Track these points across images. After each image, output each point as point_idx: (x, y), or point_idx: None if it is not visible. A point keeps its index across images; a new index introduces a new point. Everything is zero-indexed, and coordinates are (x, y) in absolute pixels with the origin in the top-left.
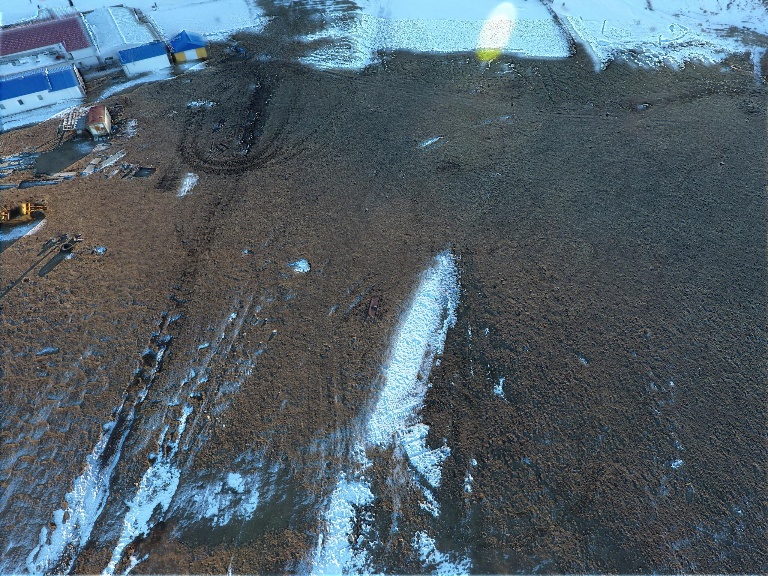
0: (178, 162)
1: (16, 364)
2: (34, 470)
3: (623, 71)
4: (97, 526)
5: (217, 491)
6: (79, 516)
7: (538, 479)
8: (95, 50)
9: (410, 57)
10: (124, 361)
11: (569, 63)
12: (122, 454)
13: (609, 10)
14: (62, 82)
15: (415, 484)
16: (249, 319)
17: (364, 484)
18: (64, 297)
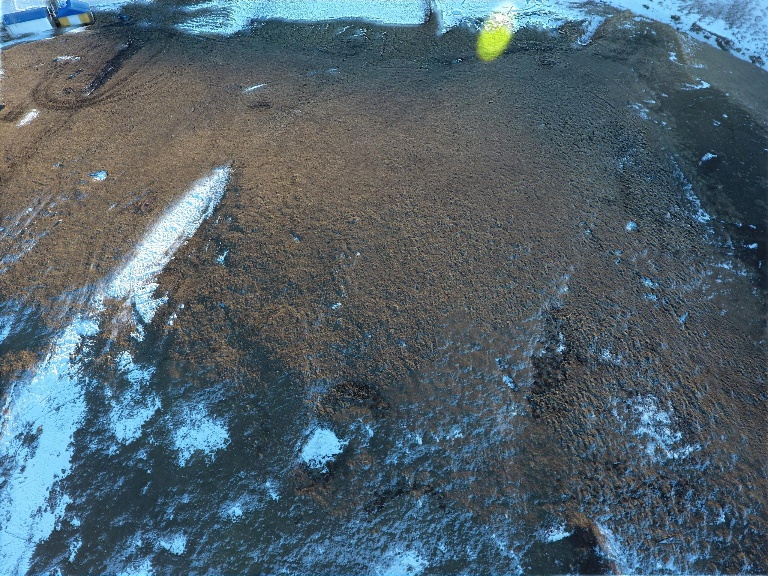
0: (27, 101)
1: None
2: None
3: (459, 34)
4: None
5: None
6: None
7: (226, 316)
8: None
9: (278, 24)
10: None
11: (417, 29)
12: None
13: None
14: None
15: (133, 322)
16: (42, 212)
17: (95, 322)
18: None
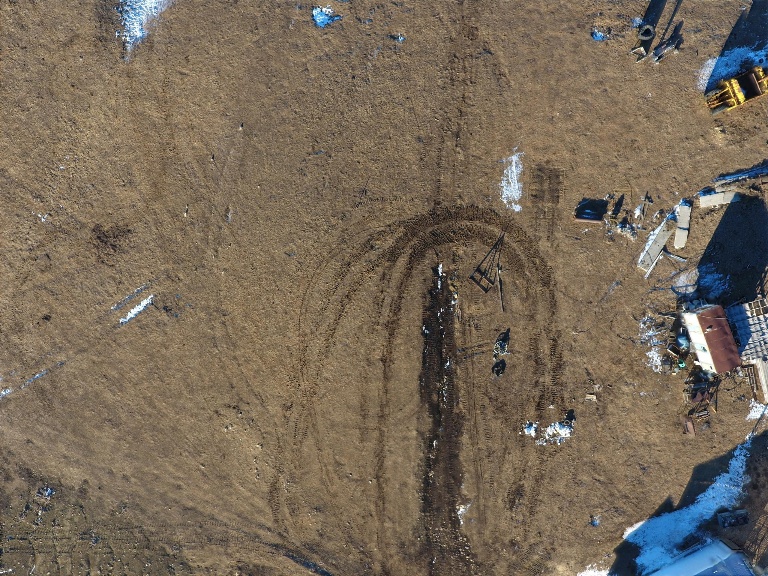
0: (546, 240)
1: None
2: None
3: None
4: None
5: None
6: None
7: None
8: None
9: None
10: None
11: None
12: None
13: None
14: None
15: None
16: None
17: None
18: None
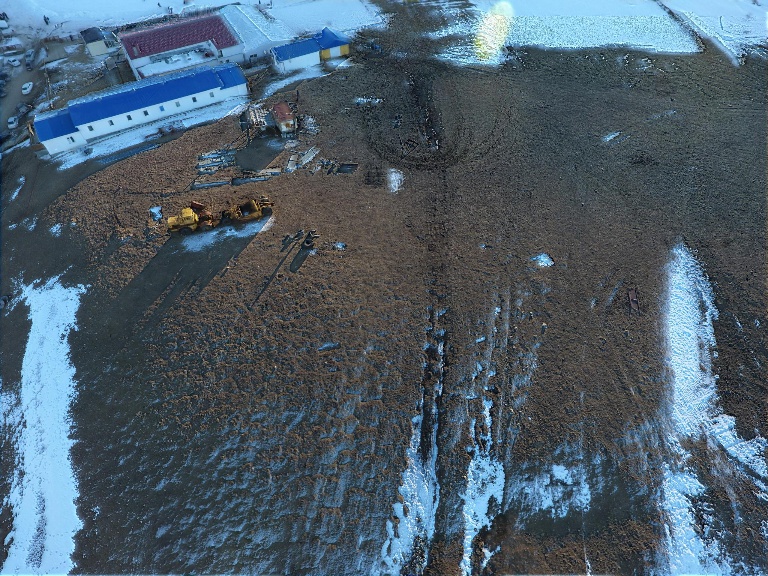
0: (375, 158)
1: (303, 359)
2: (359, 464)
3: (764, 66)
4: (440, 519)
5: (546, 483)
6: (418, 509)
7: None
8: (243, 47)
9: (542, 53)
10: (409, 355)
11: (704, 58)
12: (440, 447)
13: (718, 6)
14: (231, 79)
15: (742, 474)
16: (514, 313)
17: (690, 475)
18: (325, 292)
